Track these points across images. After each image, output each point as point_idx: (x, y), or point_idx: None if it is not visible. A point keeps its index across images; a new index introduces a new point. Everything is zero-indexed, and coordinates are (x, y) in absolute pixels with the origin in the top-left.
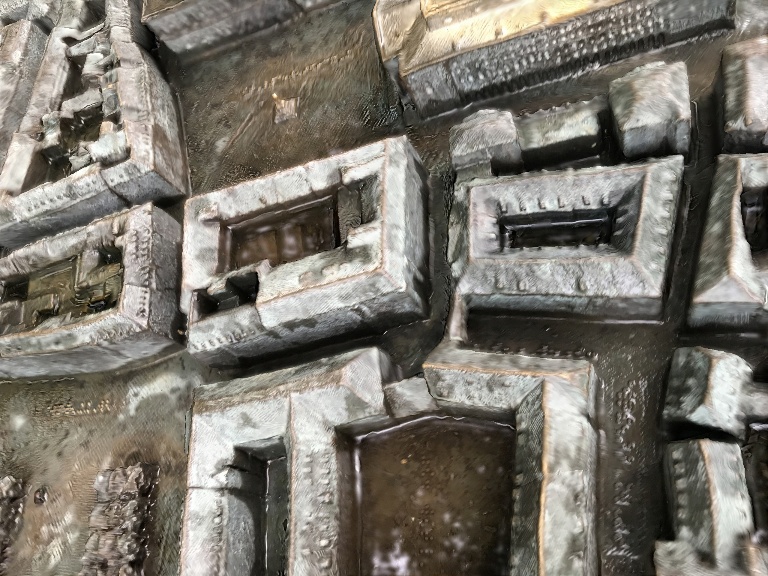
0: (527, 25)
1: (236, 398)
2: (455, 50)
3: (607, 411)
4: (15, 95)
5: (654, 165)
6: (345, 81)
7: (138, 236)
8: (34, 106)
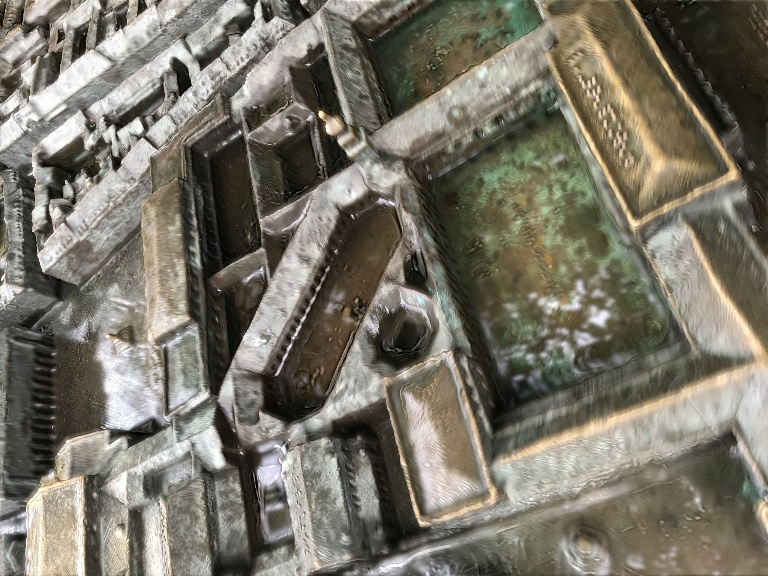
0: None
1: None
2: None
3: None
4: (147, 47)
5: None
6: (135, 391)
7: None
8: (108, 100)
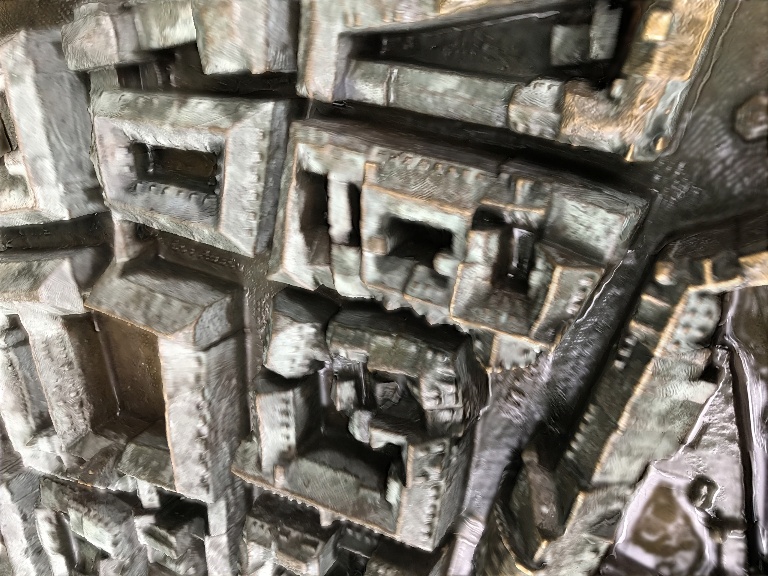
0: None
1: None
2: None
3: (252, 313)
4: None
5: (235, 127)
6: None
7: None
8: None
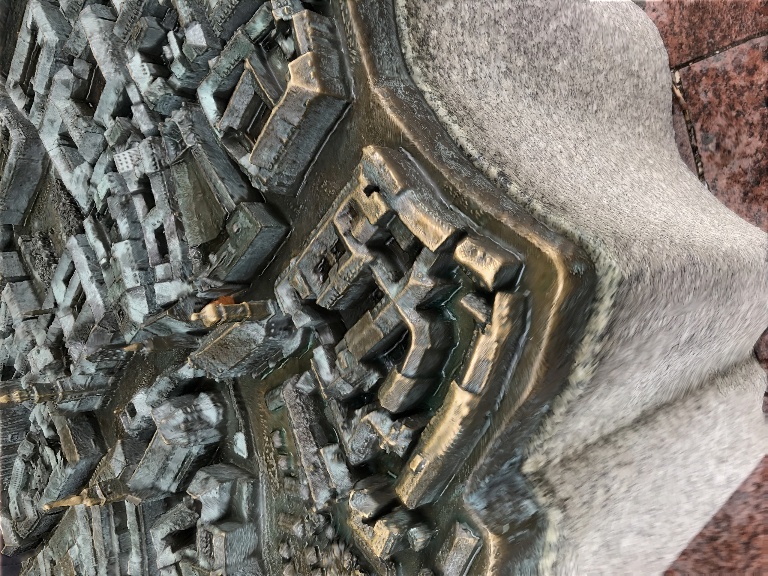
0: None
1: None
2: None
3: None
4: None
5: None
6: None
7: (7, 117)
8: None
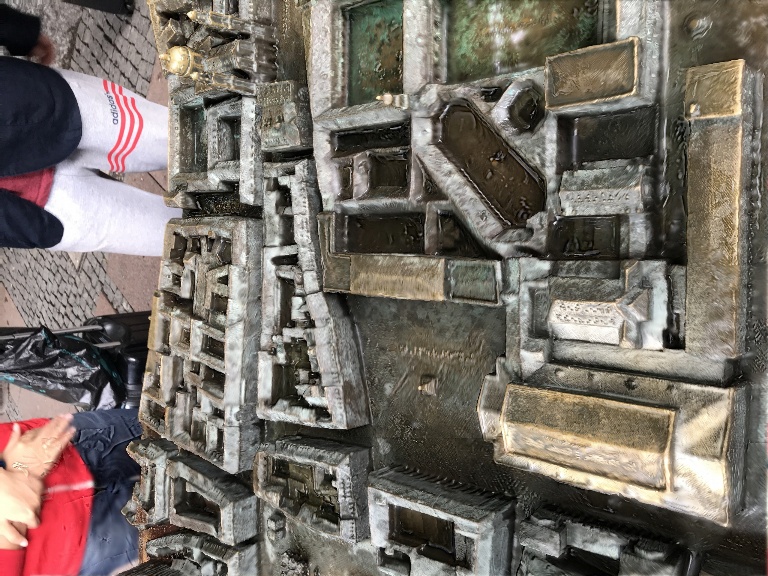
0: (577, 480)
1: None
2: (529, 468)
3: None
4: (249, 289)
5: None
6: (469, 384)
7: (344, 483)
8: (265, 326)
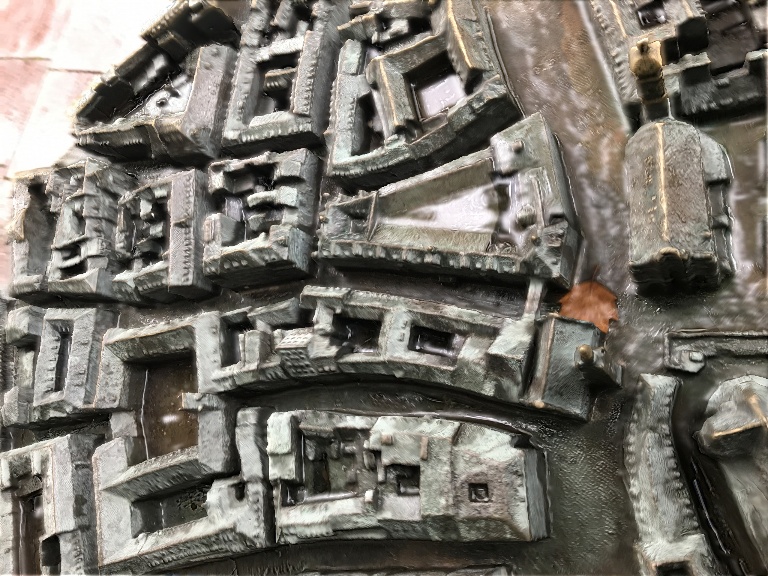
0: None
1: (98, 531)
2: None
3: None
4: None
5: None
6: None
7: None
8: None
